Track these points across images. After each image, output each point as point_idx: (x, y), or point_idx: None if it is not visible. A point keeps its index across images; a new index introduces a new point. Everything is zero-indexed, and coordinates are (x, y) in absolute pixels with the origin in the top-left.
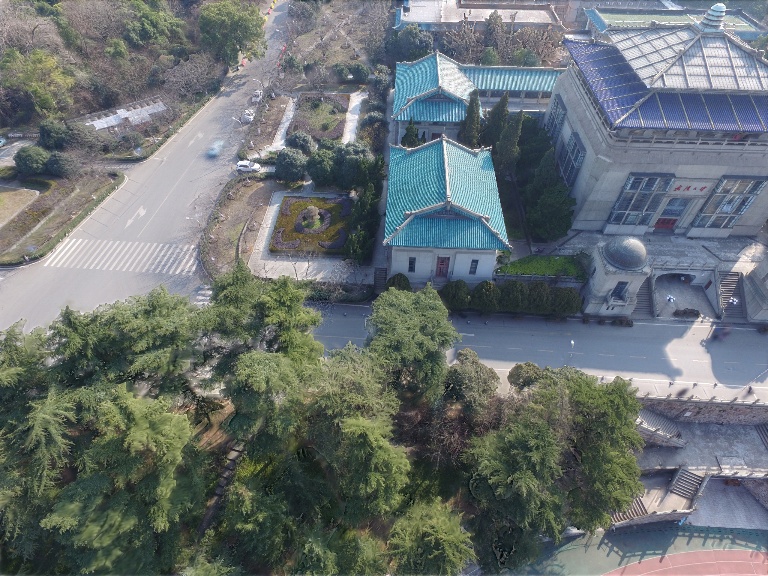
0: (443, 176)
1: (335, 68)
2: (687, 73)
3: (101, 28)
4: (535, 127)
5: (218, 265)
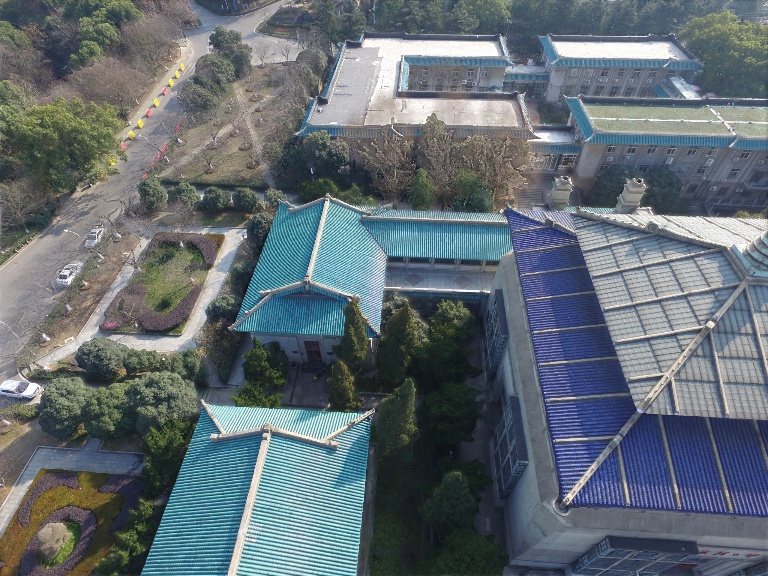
0: (231, 555)
1: (207, 195)
2: (721, 378)
3: None
4: (460, 350)
5: None
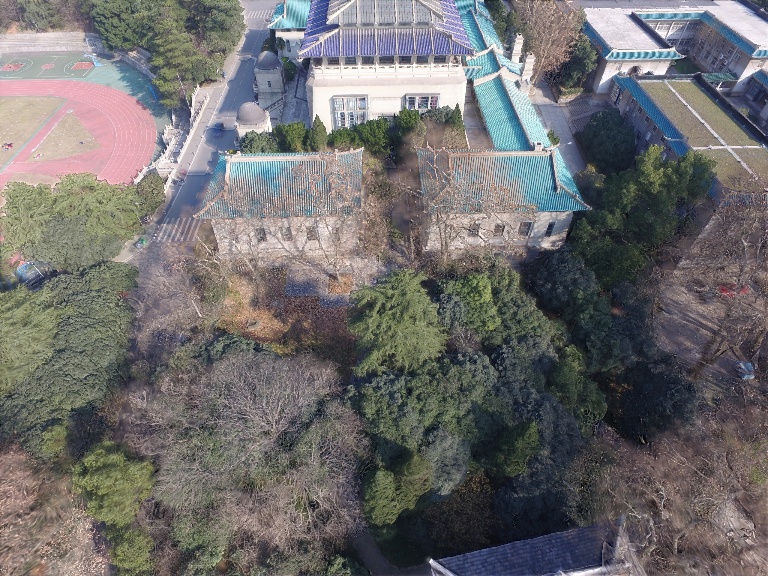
0: None
1: None
2: None
3: None
4: None
5: None
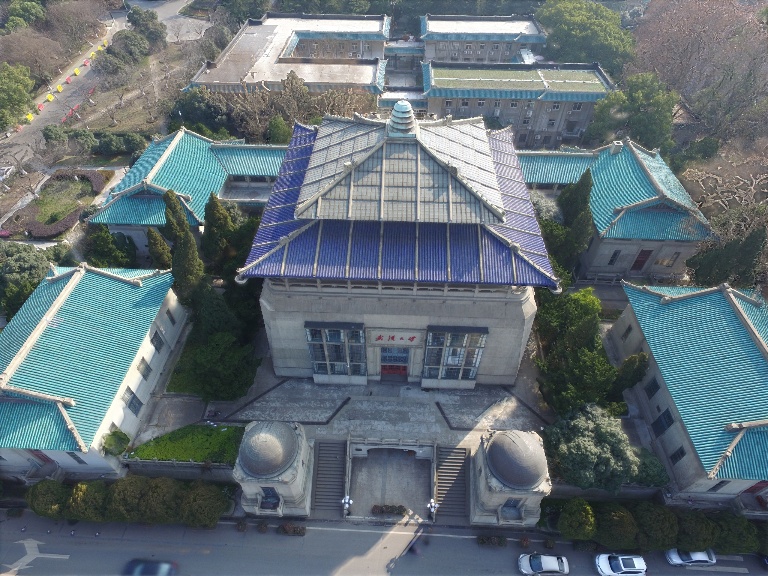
0: None
1: (102, 139)
2: (352, 197)
3: None
4: None
5: None
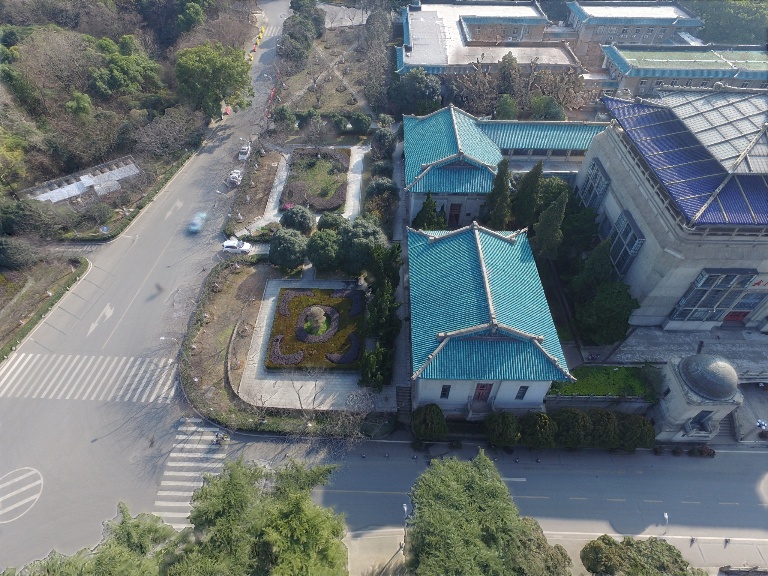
0: (481, 282)
1: (332, 119)
2: None
3: (63, 76)
4: (572, 198)
5: (202, 387)
